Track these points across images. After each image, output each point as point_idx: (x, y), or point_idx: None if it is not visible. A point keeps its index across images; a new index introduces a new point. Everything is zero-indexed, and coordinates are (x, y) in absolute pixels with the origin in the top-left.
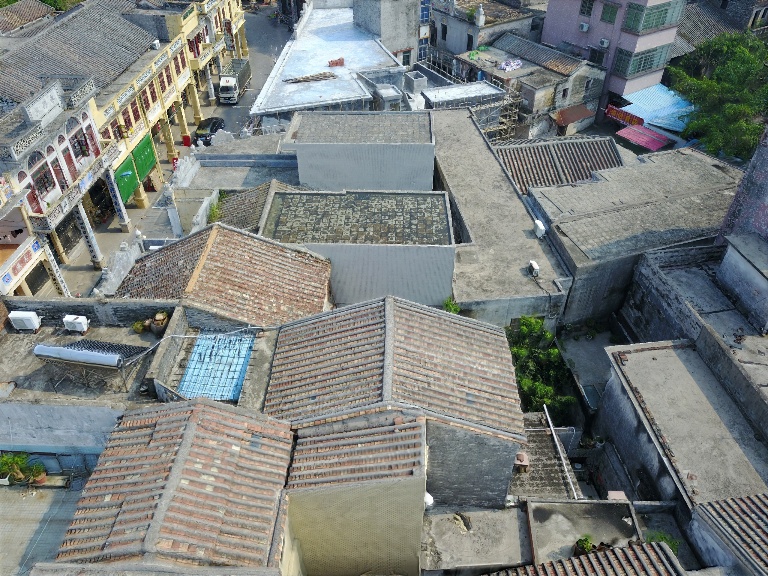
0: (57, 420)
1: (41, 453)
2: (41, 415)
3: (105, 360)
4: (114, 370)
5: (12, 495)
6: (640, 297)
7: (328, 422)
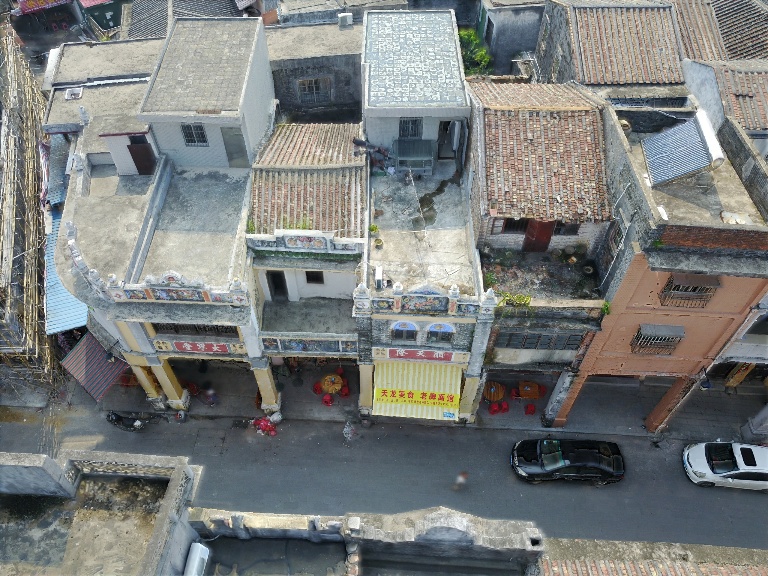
0: None
1: None
2: None
3: None
4: None
5: None
6: (413, 2)
7: None
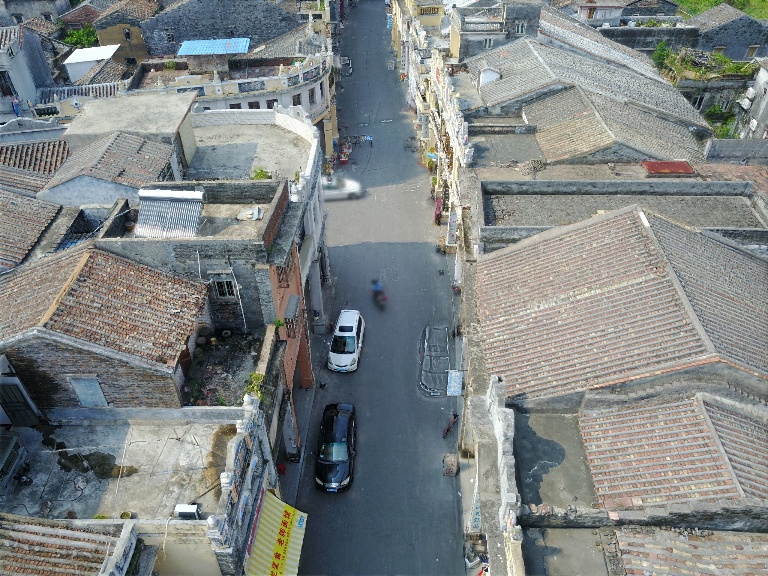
0: None
1: None
2: None
3: None
4: None
5: None
6: None
7: None
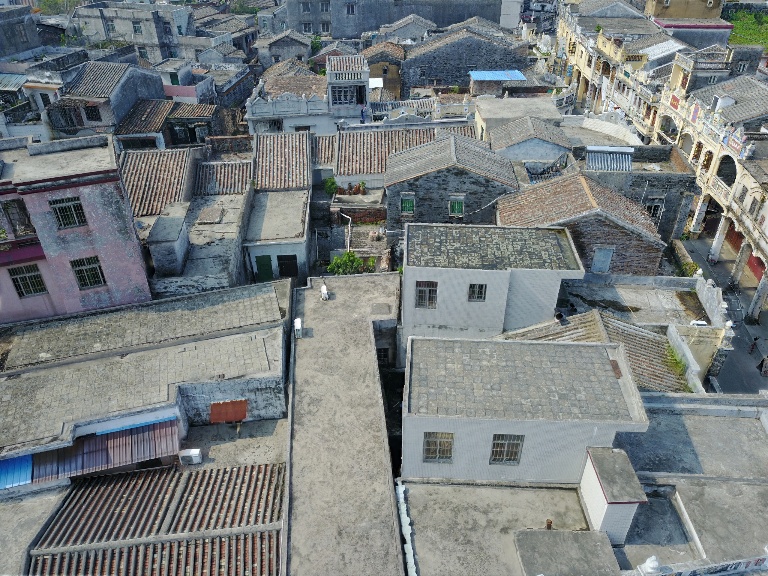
0: None
1: None
2: None
3: None
4: None
5: None
6: None
7: None
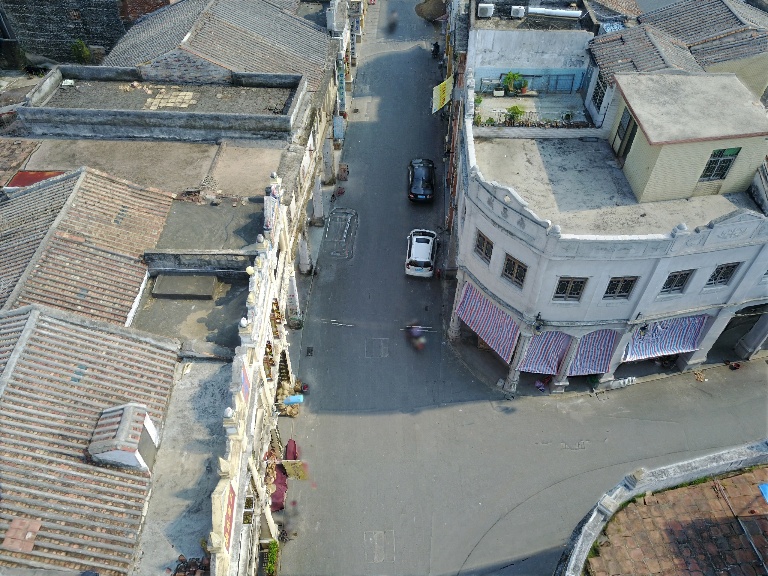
0: (551, 45)
1: (524, 75)
2: (544, 41)
3: (574, 13)
4: (575, 21)
5: (508, 100)
6: None
7: (710, 40)
